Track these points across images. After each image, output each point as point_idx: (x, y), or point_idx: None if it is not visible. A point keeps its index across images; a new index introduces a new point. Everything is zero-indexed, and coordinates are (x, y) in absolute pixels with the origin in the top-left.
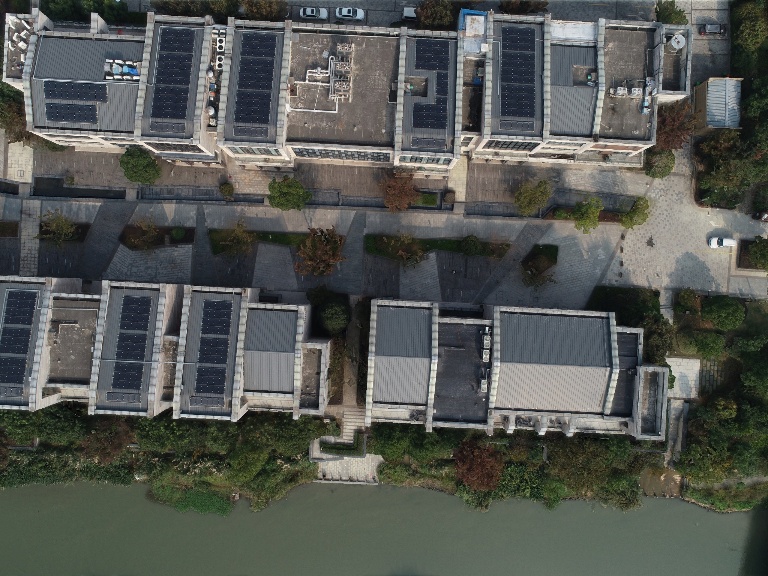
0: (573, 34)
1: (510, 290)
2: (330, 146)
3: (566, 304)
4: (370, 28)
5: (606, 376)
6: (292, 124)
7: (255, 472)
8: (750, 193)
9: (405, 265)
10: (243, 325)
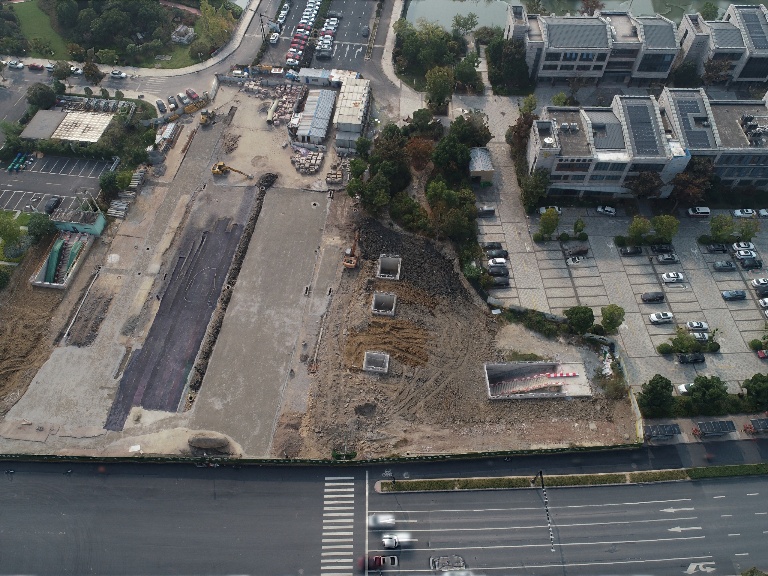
0: (611, 155)
1: (582, 94)
2: (738, 100)
3: (547, 89)
4: (744, 149)
5: (546, 23)
6: (766, 111)
7: (704, 6)
8: (445, 135)
9: (653, 94)
10: (745, 38)
